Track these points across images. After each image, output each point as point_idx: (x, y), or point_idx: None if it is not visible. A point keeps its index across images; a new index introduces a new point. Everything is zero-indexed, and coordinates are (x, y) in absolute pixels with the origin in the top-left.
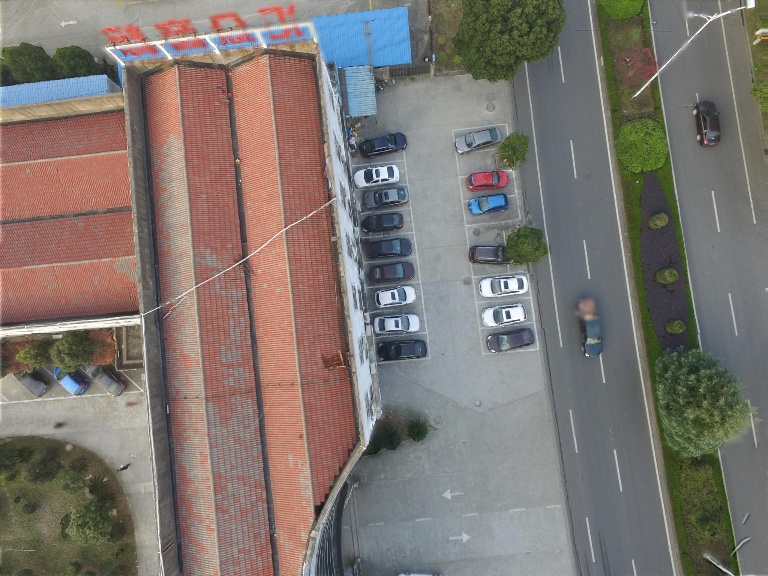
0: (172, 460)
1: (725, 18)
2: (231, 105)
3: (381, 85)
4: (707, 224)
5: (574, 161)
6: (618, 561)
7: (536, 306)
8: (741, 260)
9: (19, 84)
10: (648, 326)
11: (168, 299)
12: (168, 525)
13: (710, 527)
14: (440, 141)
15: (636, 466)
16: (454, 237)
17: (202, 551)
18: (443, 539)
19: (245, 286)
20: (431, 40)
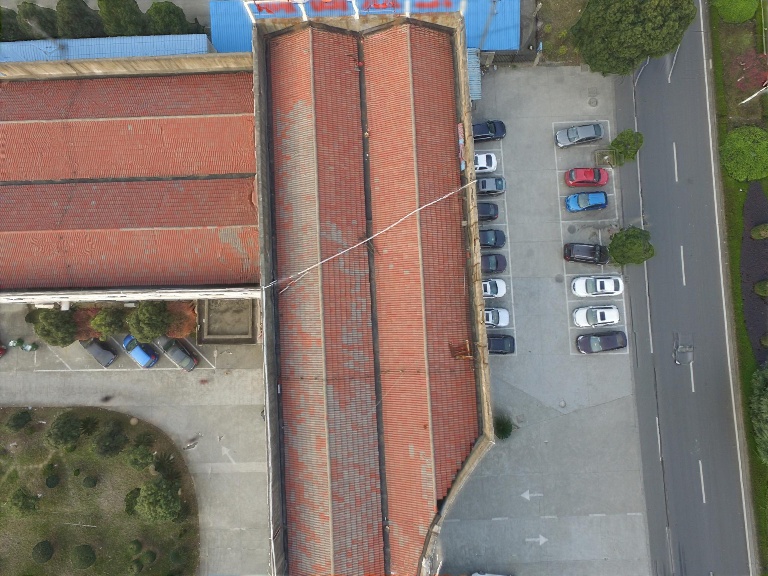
0: (281, 442)
1: None
2: (361, 75)
3: (482, 70)
4: None
5: (676, 164)
6: (696, 573)
7: (628, 309)
8: None
9: (112, 37)
10: (743, 337)
11: (286, 273)
12: (277, 510)
13: None
14: (539, 133)
15: (721, 478)
16: (548, 232)
17: (313, 539)
18: (519, 540)
19: (368, 266)
20: (536, 28)
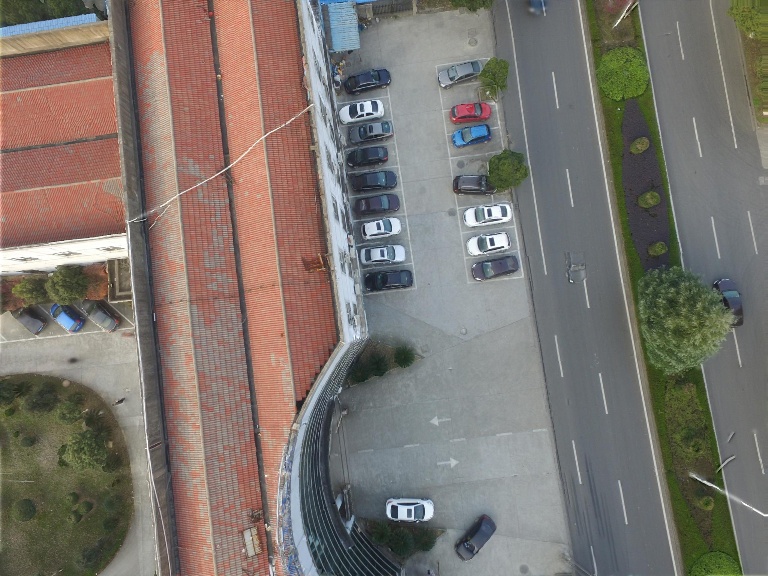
0: (159, 365)
1: None
2: (212, 24)
3: (365, 23)
4: (689, 149)
5: (556, 92)
6: (604, 482)
7: (520, 235)
8: (724, 184)
9: (11, 26)
10: (631, 250)
11: None
12: (155, 425)
13: (694, 443)
14: (424, 77)
15: (621, 388)
16: (438, 170)
17: (188, 449)
18: (431, 464)
19: (227, 196)
20: None
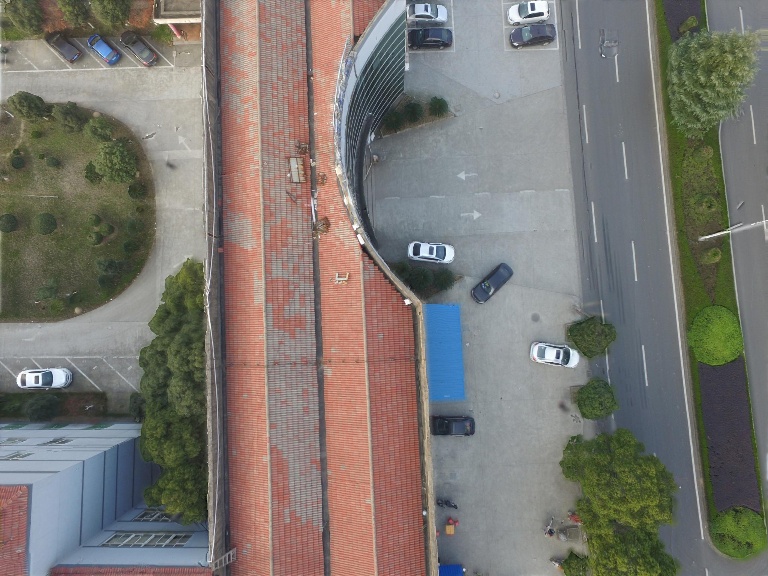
0: (217, 8)
1: None
2: None
3: None
4: None
5: None
6: (619, 241)
7: (559, 10)
8: None
9: None
10: (663, 27)
11: None
12: (211, 55)
13: (708, 199)
14: None
15: (642, 156)
16: None
17: (242, 78)
18: (455, 215)
19: None
20: None
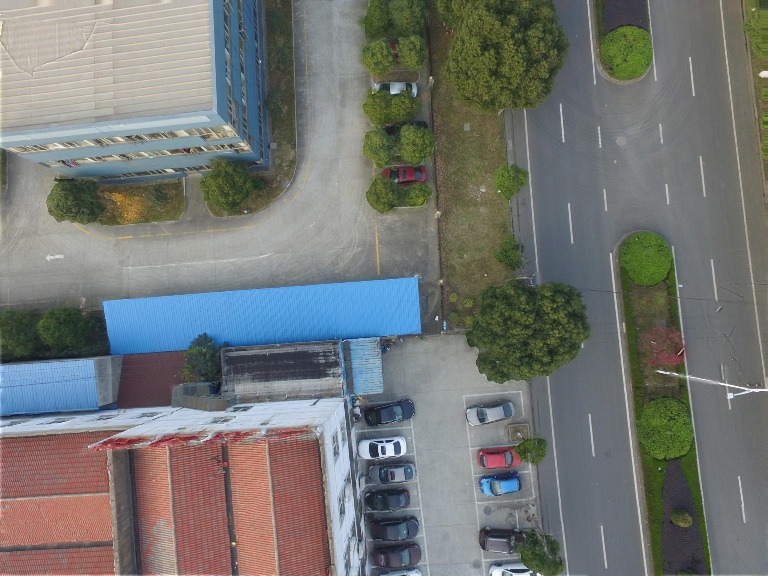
0: None
1: (756, 283)
2: (227, 475)
3: (388, 345)
4: (732, 514)
5: (592, 438)
6: None
7: None
8: (767, 554)
9: None
10: None
11: None
12: None
13: None
14: (450, 407)
15: None
16: (464, 515)
17: None
18: None
19: None
20: (442, 296)
